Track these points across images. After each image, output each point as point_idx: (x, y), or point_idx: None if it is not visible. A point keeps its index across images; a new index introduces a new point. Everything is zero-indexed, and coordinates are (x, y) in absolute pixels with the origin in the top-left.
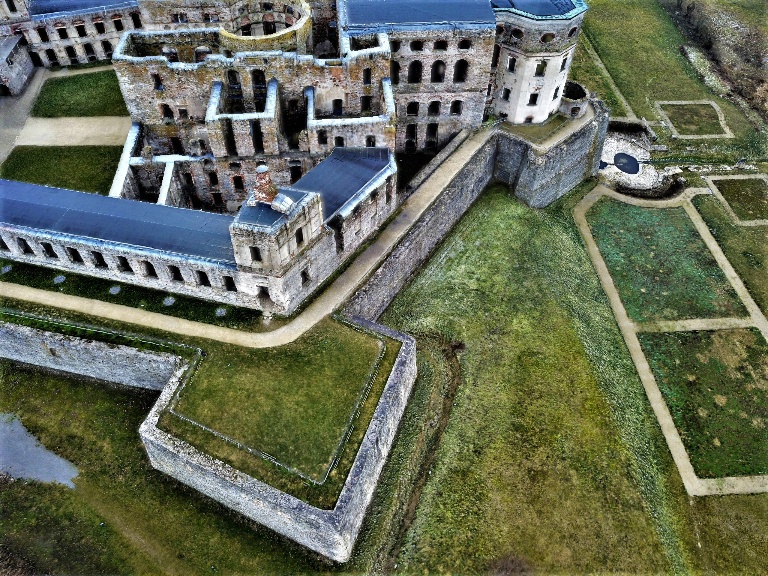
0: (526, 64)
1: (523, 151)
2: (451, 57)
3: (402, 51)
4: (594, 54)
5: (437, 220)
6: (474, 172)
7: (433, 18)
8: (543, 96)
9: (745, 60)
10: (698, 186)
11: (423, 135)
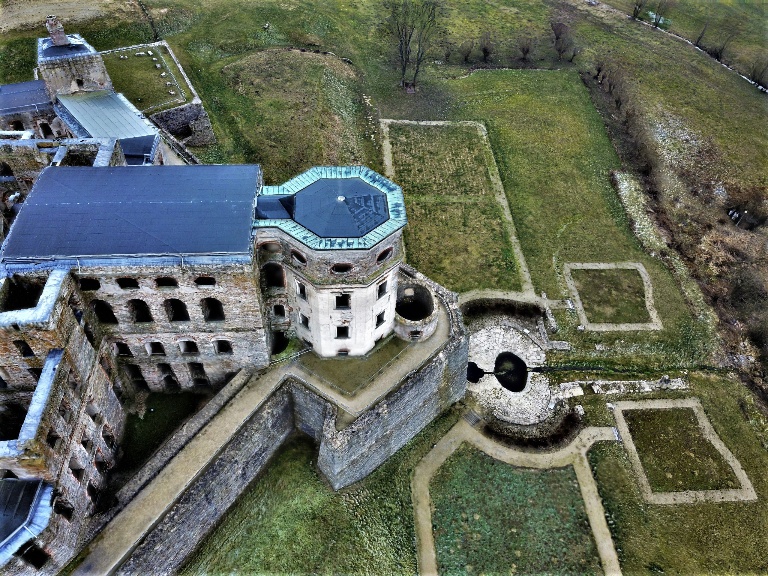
0: (318, 296)
1: (324, 412)
2: (190, 295)
3: (107, 289)
4: (498, 183)
5: (147, 568)
6: (236, 457)
7: (148, 245)
8: (356, 329)
9: (691, 192)
10: (600, 424)
11: (184, 374)
